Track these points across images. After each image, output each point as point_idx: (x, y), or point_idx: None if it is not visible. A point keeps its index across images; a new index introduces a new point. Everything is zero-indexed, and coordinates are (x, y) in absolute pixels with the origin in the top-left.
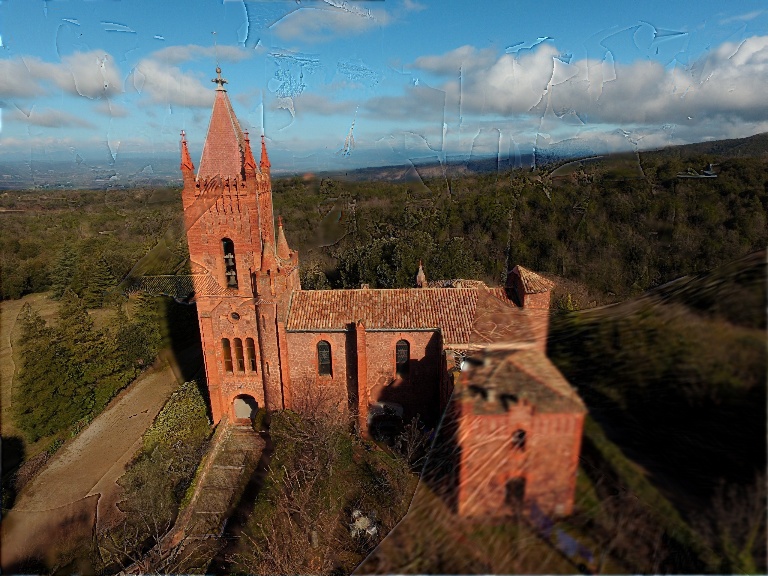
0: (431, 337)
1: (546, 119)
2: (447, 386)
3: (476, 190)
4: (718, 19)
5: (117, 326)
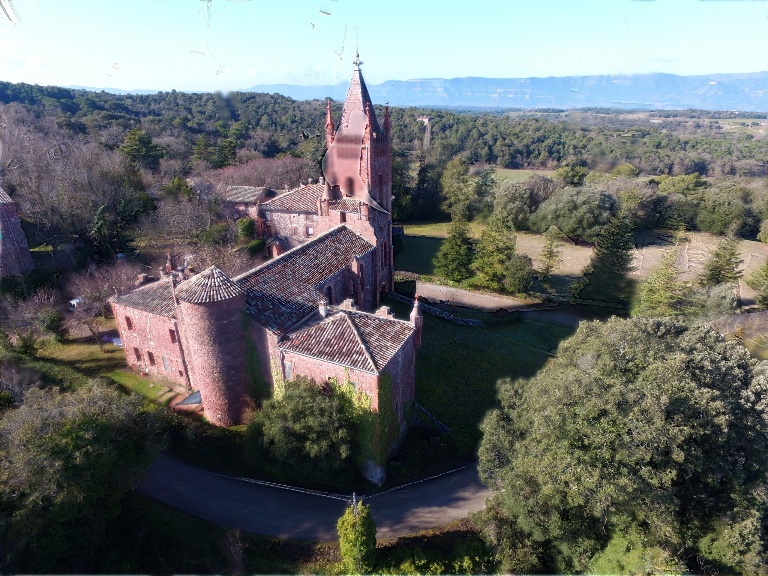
0: None
1: None
2: None
3: None
4: None
5: (540, 257)
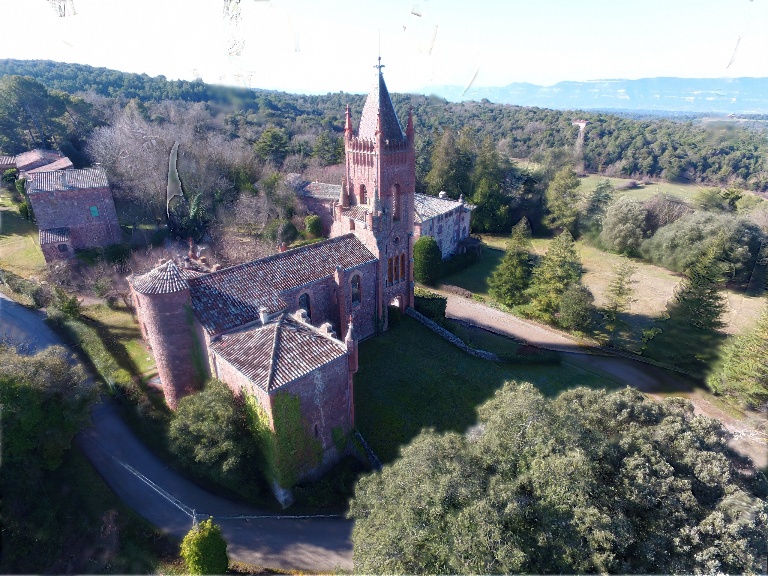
0: None
1: None
2: None
3: None
4: None
5: (607, 292)
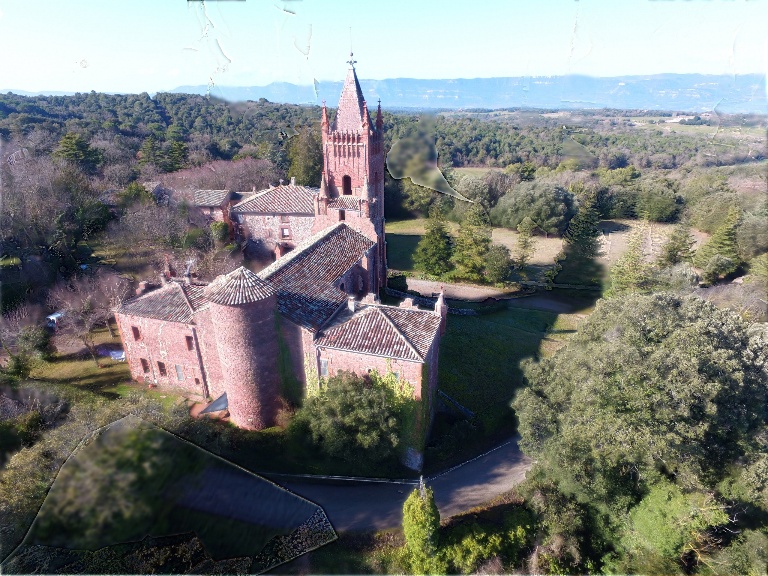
0: None
1: None
2: None
3: None
4: None
5: (515, 247)
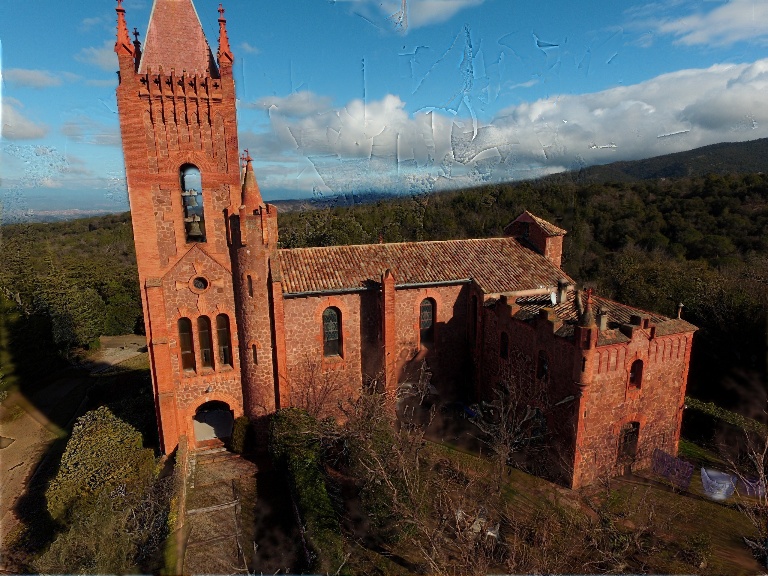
0: (459, 292)
1: (463, 106)
2: (501, 341)
3: (378, 191)
4: (600, 23)
5: None
